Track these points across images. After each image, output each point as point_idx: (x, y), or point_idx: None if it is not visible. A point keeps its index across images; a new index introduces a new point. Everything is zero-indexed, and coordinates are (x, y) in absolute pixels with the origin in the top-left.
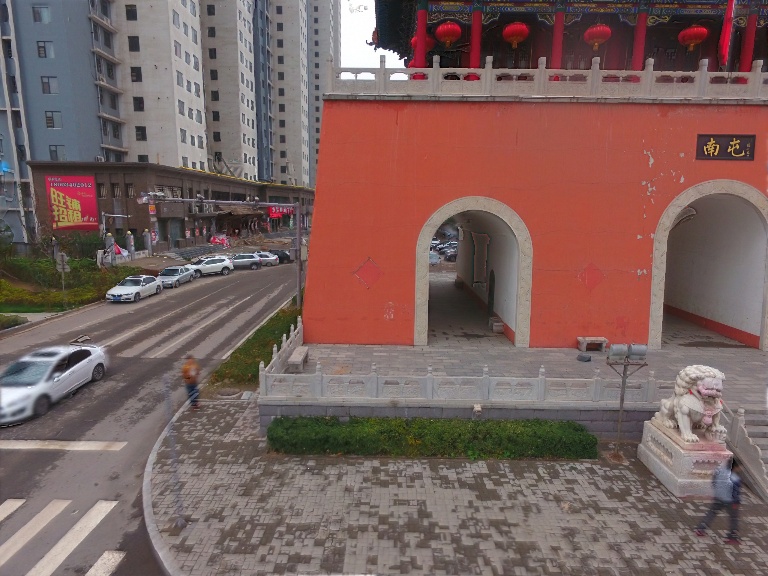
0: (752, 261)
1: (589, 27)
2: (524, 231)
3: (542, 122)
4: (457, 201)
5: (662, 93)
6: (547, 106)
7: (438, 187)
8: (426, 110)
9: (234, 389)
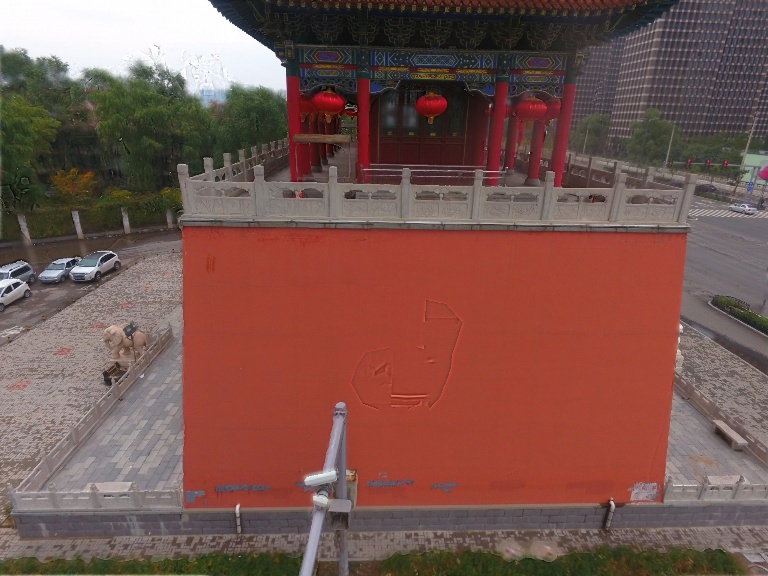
0: None
1: None
2: None
3: None
4: None
5: None
6: None
7: None
8: None
9: (756, 574)
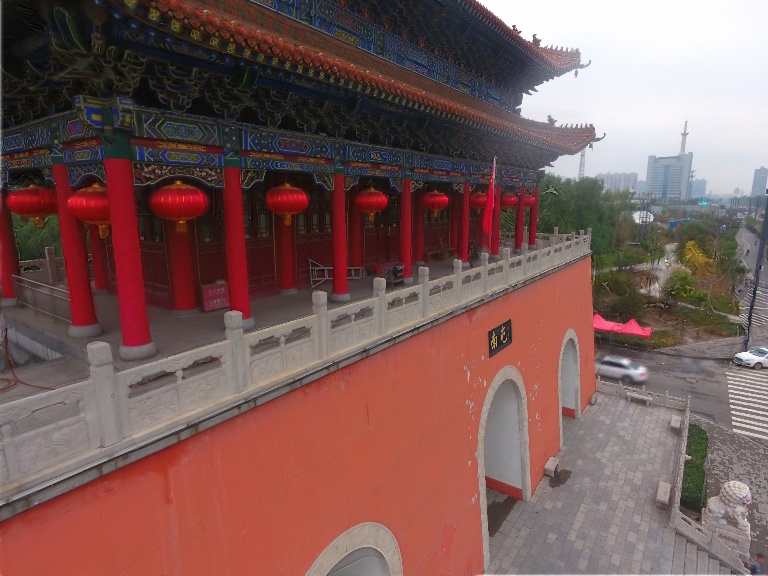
0: (504, 421)
1: (363, 192)
2: (391, 542)
3: (389, 374)
4: (310, 572)
5: (466, 295)
6: (392, 349)
7: (276, 572)
8: (231, 435)
9: None
